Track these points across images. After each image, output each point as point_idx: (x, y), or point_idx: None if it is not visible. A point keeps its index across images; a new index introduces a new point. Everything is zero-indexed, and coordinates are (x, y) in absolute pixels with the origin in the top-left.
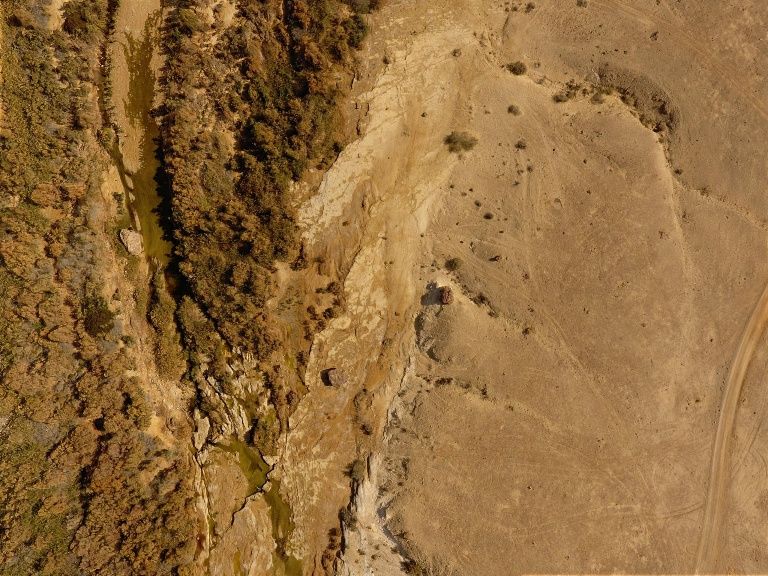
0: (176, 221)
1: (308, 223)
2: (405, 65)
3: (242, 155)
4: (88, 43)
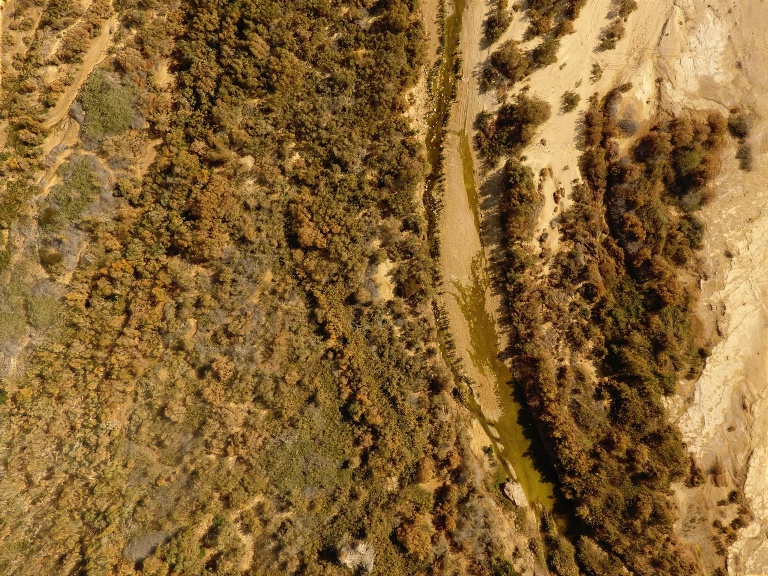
0: (568, 469)
1: (692, 437)
2: (750, 255)
3: (614, 385)
4: (426, 304)
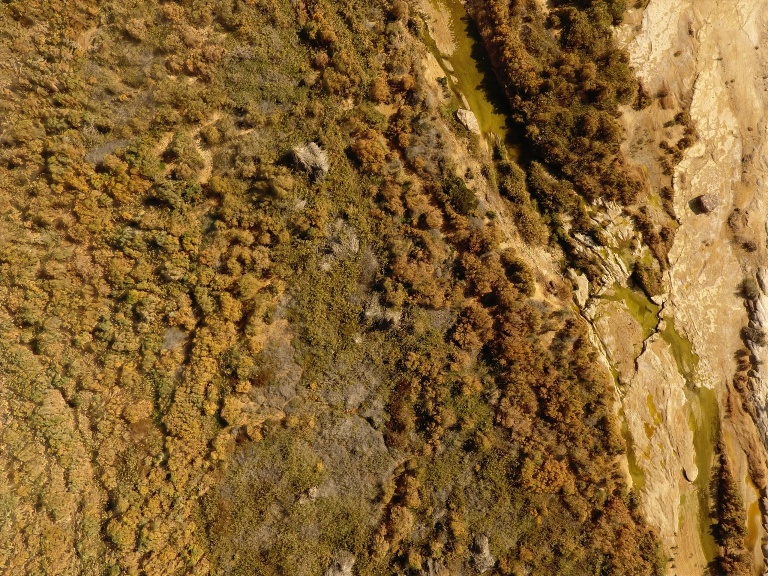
0: (517, 85)
1: (639, 62)
2: None
3: (563, 9)
4: None
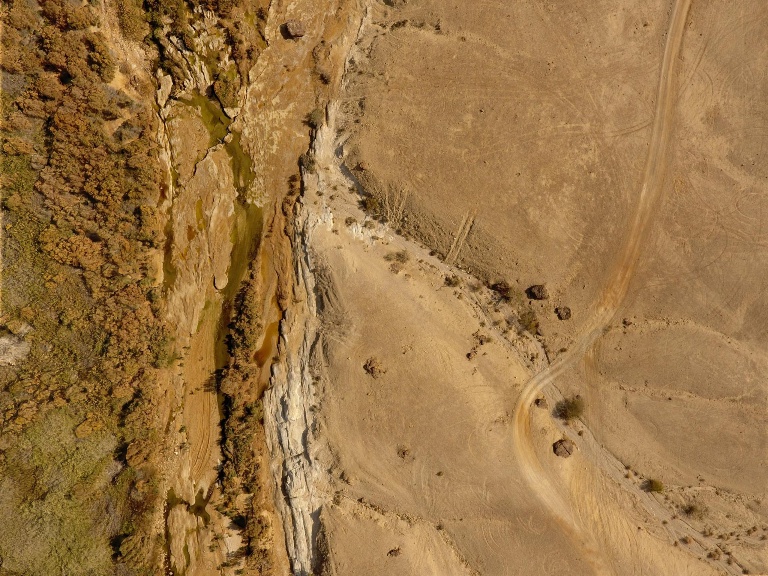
0: None
1: None
2: None
3: None
4: None
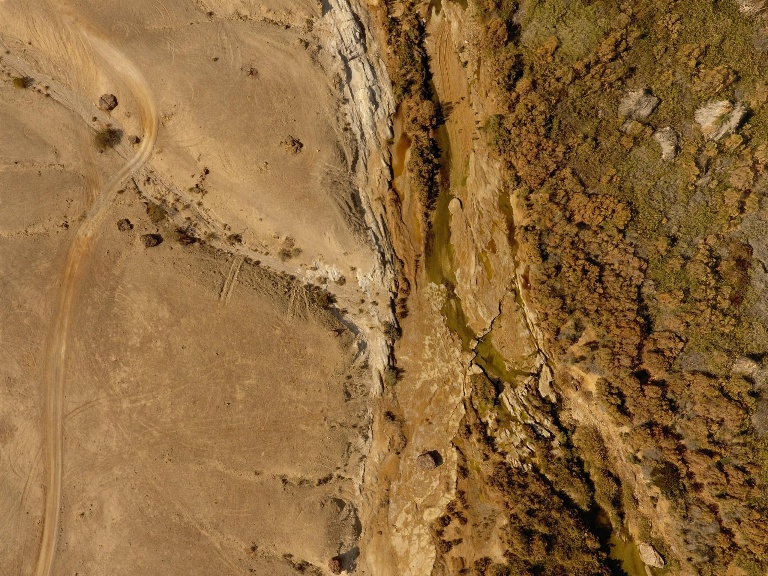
0: None
1: None
2: None
3: None
4: None
